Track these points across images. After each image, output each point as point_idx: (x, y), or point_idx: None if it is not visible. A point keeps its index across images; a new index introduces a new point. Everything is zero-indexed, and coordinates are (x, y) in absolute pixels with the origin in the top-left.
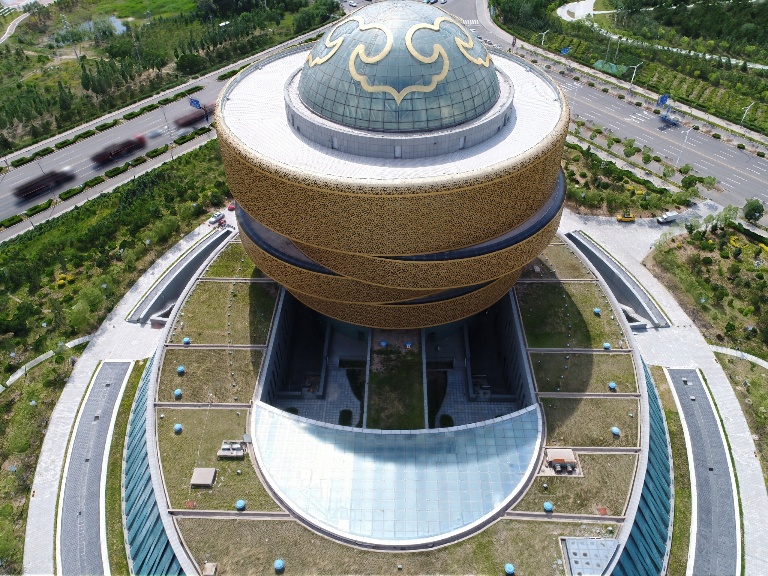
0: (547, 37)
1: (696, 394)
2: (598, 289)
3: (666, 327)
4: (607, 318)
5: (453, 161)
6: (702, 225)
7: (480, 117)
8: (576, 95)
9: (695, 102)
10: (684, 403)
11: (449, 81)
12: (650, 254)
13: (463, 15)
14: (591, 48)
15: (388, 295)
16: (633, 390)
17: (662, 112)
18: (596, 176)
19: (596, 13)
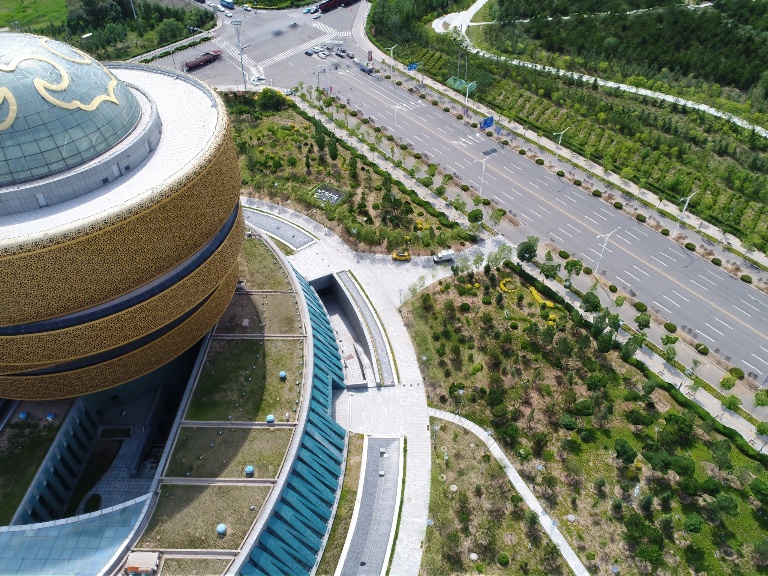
0: (410, 51)
1: (387, 469)
2: (300, 347)
3: (390, 386)
4: (292, 383)
5: (22, 222)
6: (470, 266)
7: (73, 169)
8: (414, 115)
9: (532, 123)
10: (369, 480)
11: (17, 130)
12: (411, 298)
13: (338, 26)
14: (449, 63)
15: (0, 366)
16: (272, 475)
17: (495, 134)
18: (385, 208)
19: (471, 25)
